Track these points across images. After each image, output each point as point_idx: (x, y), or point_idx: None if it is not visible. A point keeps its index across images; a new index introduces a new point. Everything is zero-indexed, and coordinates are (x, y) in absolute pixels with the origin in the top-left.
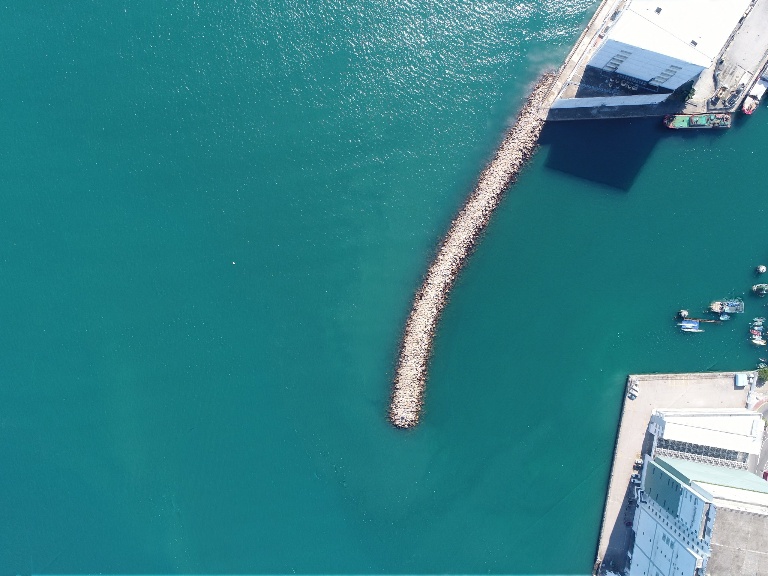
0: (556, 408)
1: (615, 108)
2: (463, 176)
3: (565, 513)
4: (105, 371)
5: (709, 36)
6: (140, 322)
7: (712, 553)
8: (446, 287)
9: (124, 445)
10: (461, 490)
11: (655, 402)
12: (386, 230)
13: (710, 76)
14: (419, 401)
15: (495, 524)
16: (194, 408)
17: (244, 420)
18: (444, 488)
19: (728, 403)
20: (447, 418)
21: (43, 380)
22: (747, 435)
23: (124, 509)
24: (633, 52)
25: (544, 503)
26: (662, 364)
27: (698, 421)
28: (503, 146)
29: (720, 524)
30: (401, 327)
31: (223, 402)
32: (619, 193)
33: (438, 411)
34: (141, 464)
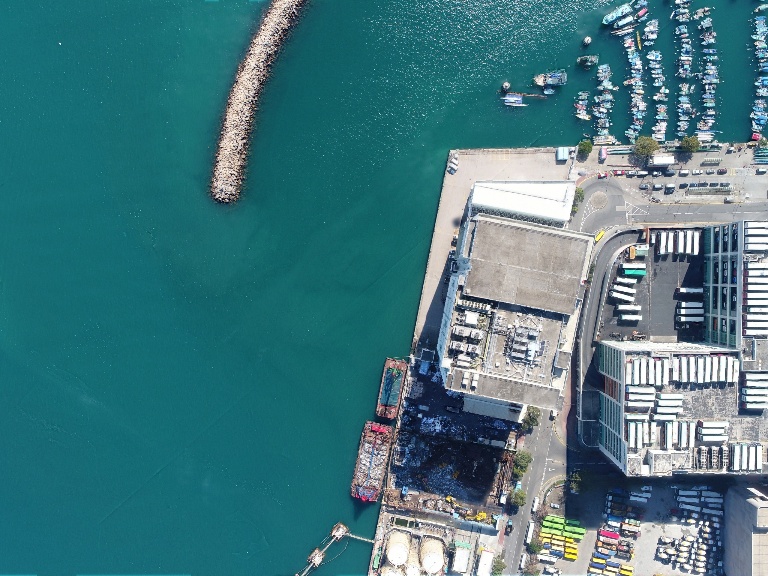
0: (377, 184)
1: None
2: None
3: (383, 290)
4: None
5: None
6: None
7: (473, 268)
8: (269, 59)
9: None
10: (280, 266)
11: (475, 177)
12: (211, 2)
13: None
14: (240, 175)
15: (314, 301)
16: (4, 163)
17: (53, 175)
18: (264, 264)
19: (549, 178)
20: (270, 195)
21: None
22: (557, 200)
23: None
24: None
25: (363, 281)
26: (484, 139)
27: (510, 188)
28: None
29: (481, 238)
30: (224, 101)
31: (33, 157)
32: None
33: (261, 188)
34: None
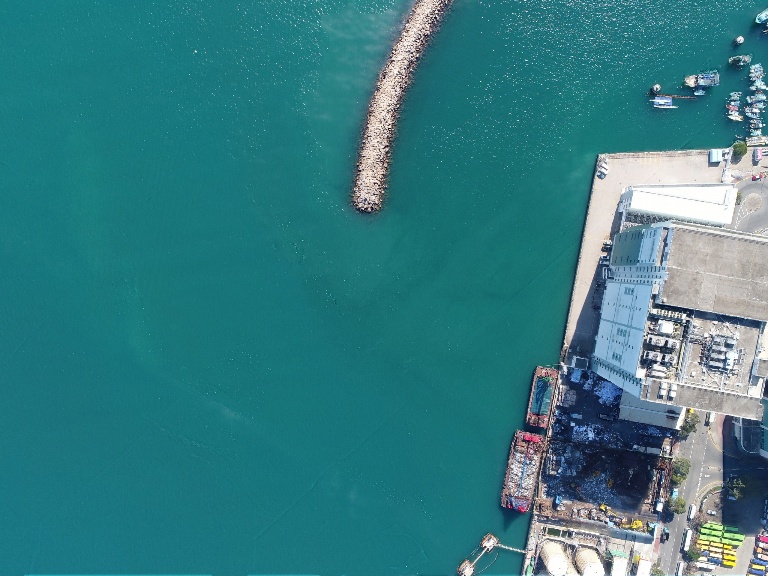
0: (523, 190)
1: None
2: None
3: (531, 298)
4: (65, 147)
5: None
6: (98, 91)
7: (669, 276)
8: (410, 66)
9: (86, 227)
10: (425, 275)
11: (625, 181)
12: (349, 8)
13: None
14: (382, 184)
15: (460, 310)
16: (152, 177)
17: (202, 189)
18: (408, 273)
19: (702, 181)
20: (411, 204)
21: (3, 152)
22: (719, 203)
23: (87, 295)
24: None
25: (510, 289)
26: (633, 143)
27: (668, 192)
28: None
29: (677, 246)
30: (364, 109)
31: (180, 171)
32: None
33: (402, 197)
34: (103, 246)
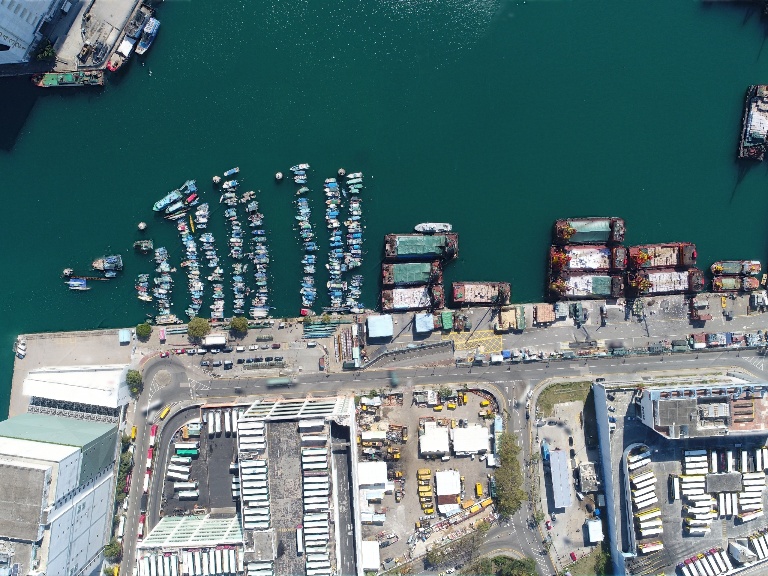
0: None
1: None
2: None
3: None
4: None
5: None
6: None
7: None
8: None
9: None
10: None
11: (44, 360)
12: None
13: (79, 33)
14: None
15: None
16: None
17: None
18: None
19: (115, 359)
20: None
21: None
22: (104, 389)
23: None
24: None
25: None
26: (52, 323)
27: (64, 377)
28: None
29: None
30: None
31: None
32: None
33: None
34: None
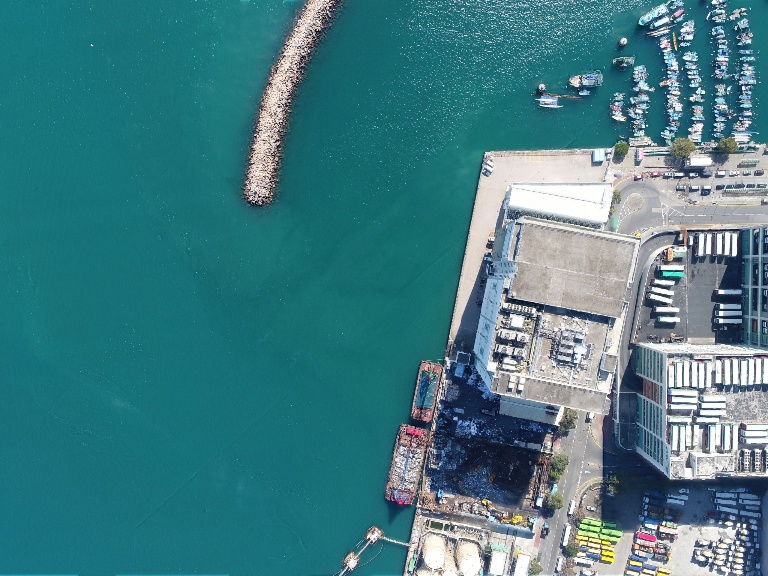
0: (411, 186)
1: None
2: None
3: (418, 293)
4: None
5: None
6: None
7: (519, 271)
8: (302, 61)
9: None
10: (314, 269)
11: (510, 179)
12: (243, 4)
13: None
14: (273, 178)
15: (348, 304)
16: (39, 166)
17: (87, 179)
18: (297, 267)
19: (585, 180)
20: (303, 198)
21: None
22: (595, 201)
23: None
24: None
25: (397, 283)
26: (519, 141)
27: (547, 190)
28: None
29: (527, 241)
30: (257, 103)
31: (67, 160)
32: None
33: (294, 191)
34: None
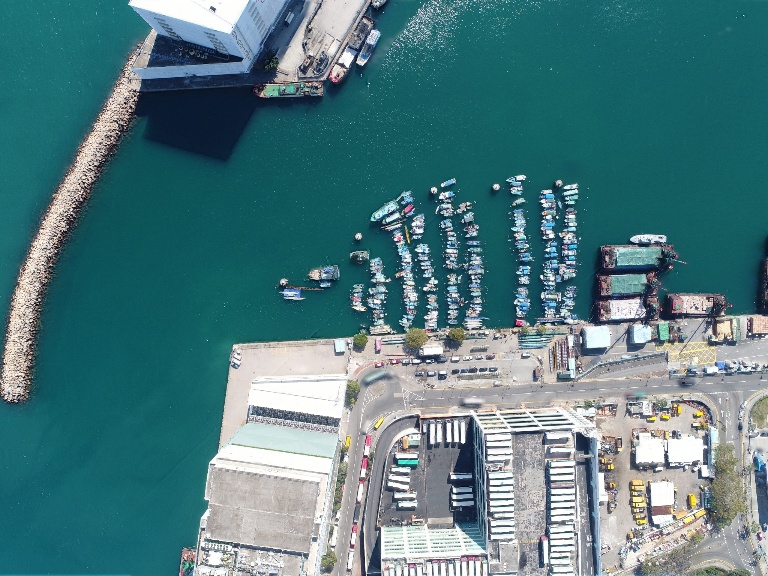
0: (165, 379)
1: (207, 78)
2: (64, 149)
3: (177, 482)
4: None
5: (226, 1)
6: None
7: (212, 513)
8: (49, 261)
9: None
10: (74, 463)
11: (258, 370)
12: None
13: (300, 44)
14: (28, 376)
15: (110, 495)
16: None
17: None
18: (57, 461)
19: (329, 369)
20: (61, 392)
21: None
22: (329, 399)
23: None
24: (164, 19)
25: (157, 473)
26: (266, 332)
27: (286, 387)
28: (99, 118)
29: (218, 484)
30: (8, 302)
31: None
32: (215, 163)
33: (52, 385)
34: None
